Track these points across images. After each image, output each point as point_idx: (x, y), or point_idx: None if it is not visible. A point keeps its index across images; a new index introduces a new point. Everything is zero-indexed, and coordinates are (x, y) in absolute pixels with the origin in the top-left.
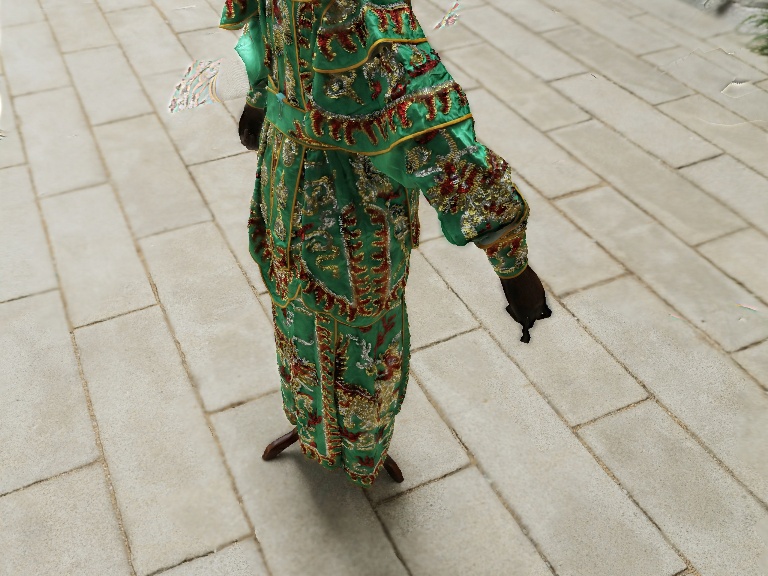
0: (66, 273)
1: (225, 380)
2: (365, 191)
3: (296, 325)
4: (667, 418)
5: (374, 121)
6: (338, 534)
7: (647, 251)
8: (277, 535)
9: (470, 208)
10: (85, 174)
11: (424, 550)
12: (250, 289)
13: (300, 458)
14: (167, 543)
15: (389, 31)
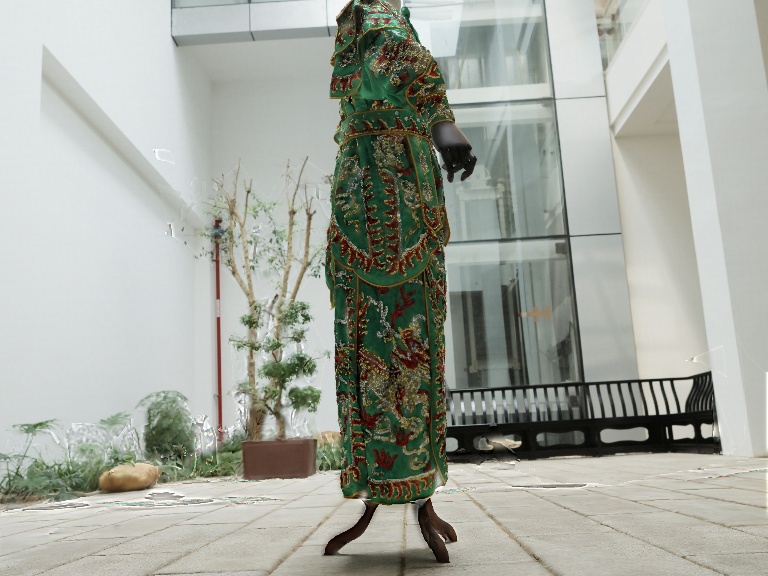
0: (261, 520)
1: None
2: (379, 159)
3: (337, 305)
4: None
5: None
6: (350, 572)
7: None
8: (292, 570)
9: None
10: (323, 504)
11: None
12: None
13: None
14: (193, 567)
15: None
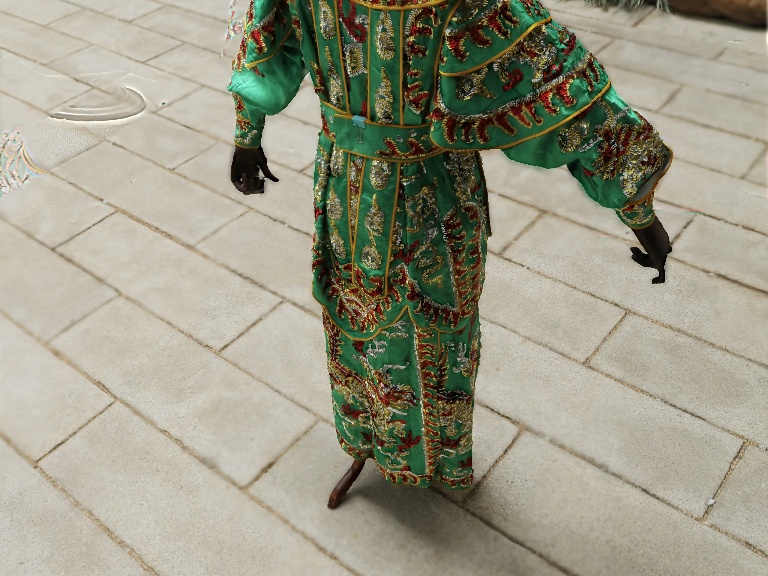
0: None
1: (241, 449)
2: (462, 190)
3: (390, 352)
4: (652, 325)
5: (509, 112)
6: (448, 546)
7: (546, 188)
8: (392, 574)
9: (627, 168)
10: None
11: (532, 525)
12: (206, 350)
13: (365, 492)
14: None
15: (533, 14)
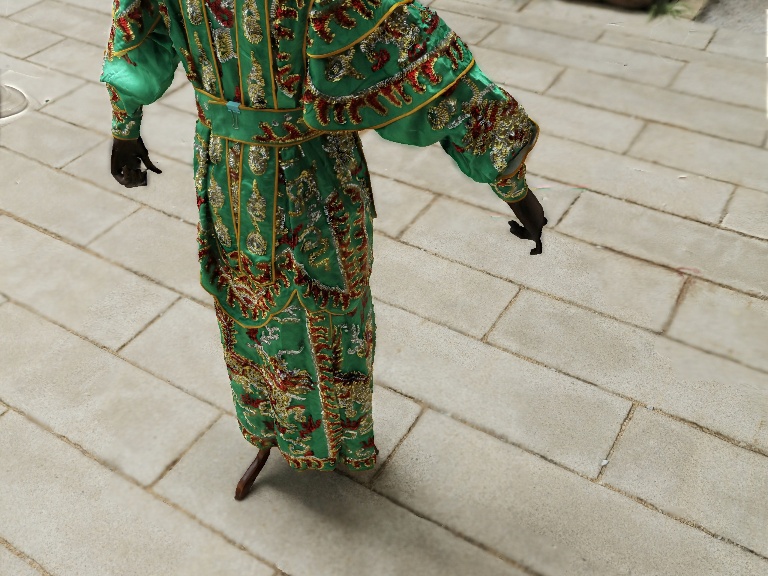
0: None
1: (143, 448)
2: (342, 173)
3: (284, 338)
4: (544, 298)
5: (379, 92)
6: (356, 527)
7: (440, 172)
8: (302, 559)
9: (496, 143)
10: None
11: (437, 499)
12: (103, 351)
13: (272, 481)
14: None
15: None
